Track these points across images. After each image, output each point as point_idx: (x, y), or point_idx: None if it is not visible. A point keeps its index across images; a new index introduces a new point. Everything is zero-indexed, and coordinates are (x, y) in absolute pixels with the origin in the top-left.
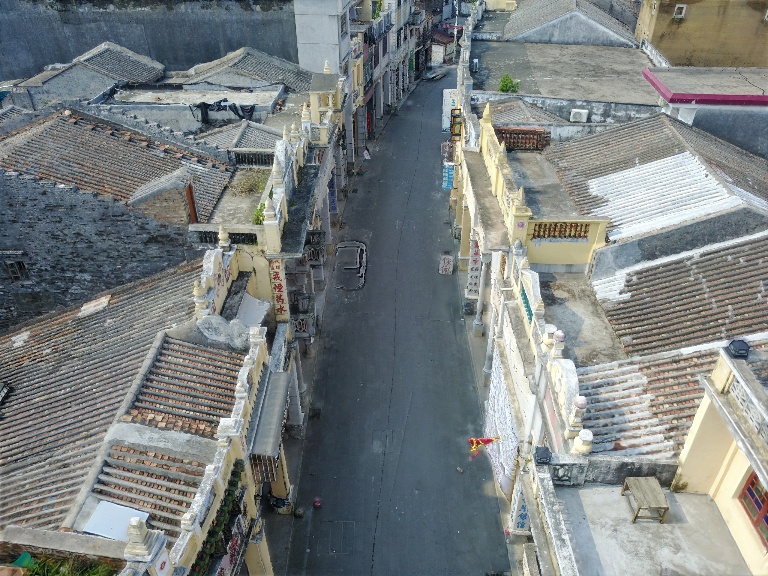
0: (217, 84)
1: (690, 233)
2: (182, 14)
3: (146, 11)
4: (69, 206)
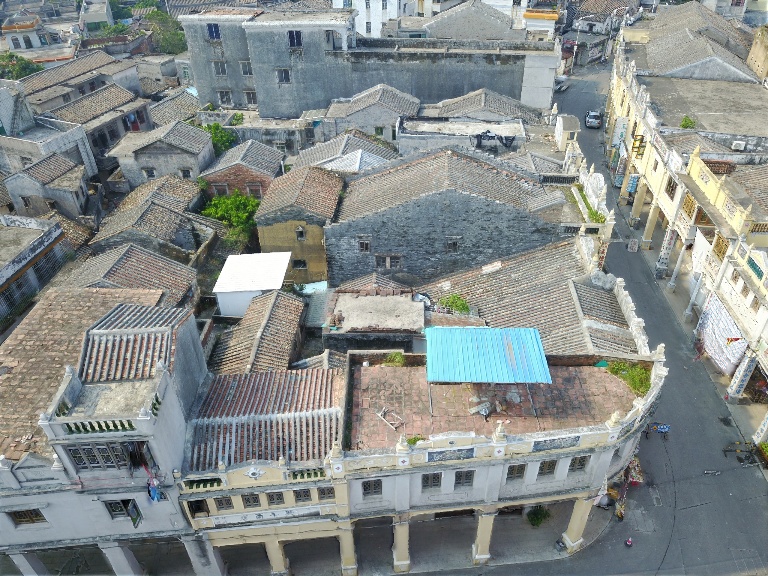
0: (475, 118)
1: None
2: (442, 66)
3: (416, 64)
4: (498, 212)
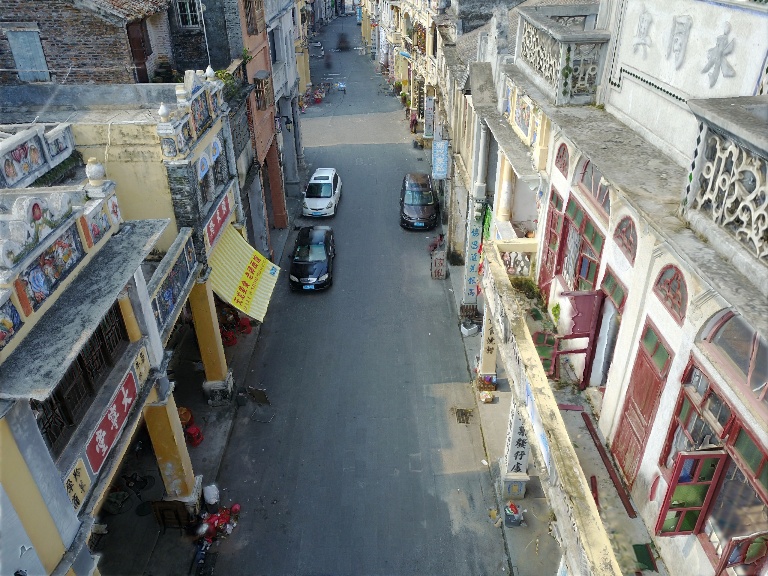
0: None
1: None
2: None
3: None
4: None
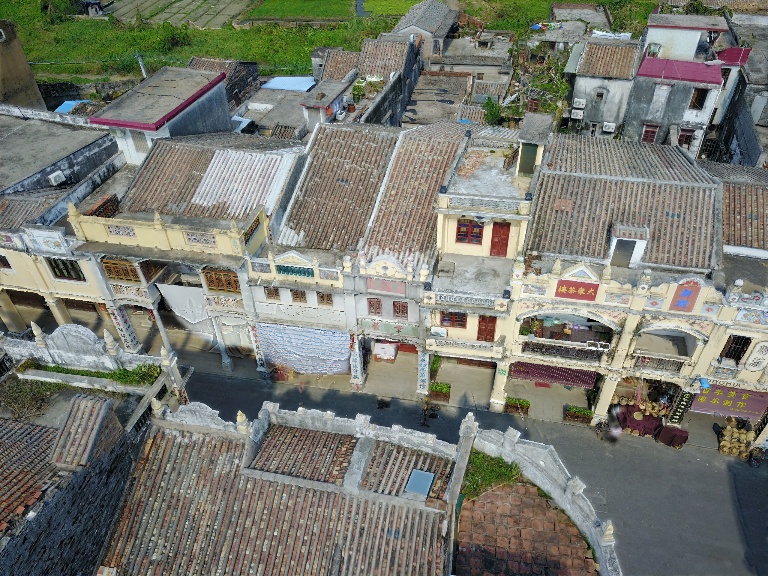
0: None
1: (290, 184)
2: None
3: None
4: (46, 525)
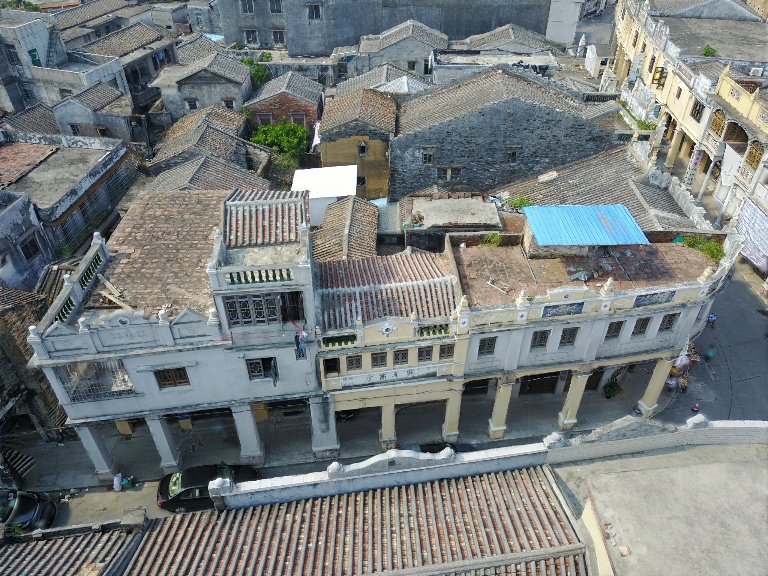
0: (506, 51)
1: None
2: (471, 1)
3: None
4: (557, 121)
